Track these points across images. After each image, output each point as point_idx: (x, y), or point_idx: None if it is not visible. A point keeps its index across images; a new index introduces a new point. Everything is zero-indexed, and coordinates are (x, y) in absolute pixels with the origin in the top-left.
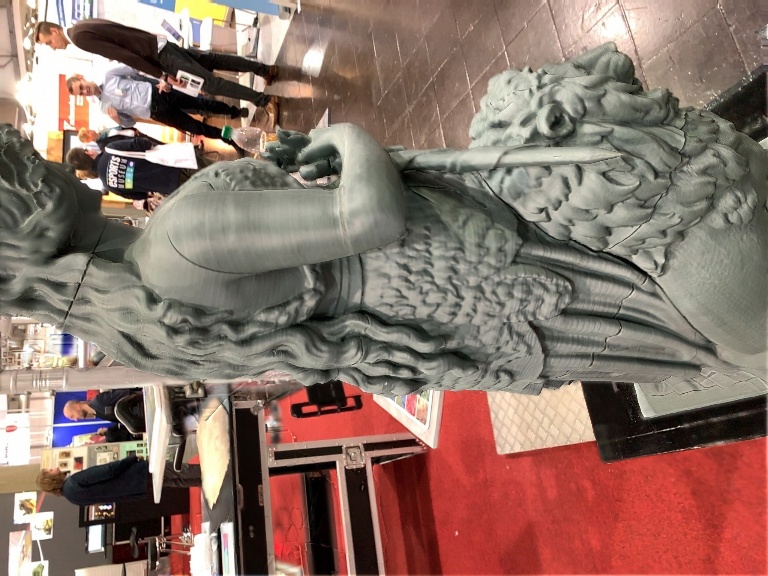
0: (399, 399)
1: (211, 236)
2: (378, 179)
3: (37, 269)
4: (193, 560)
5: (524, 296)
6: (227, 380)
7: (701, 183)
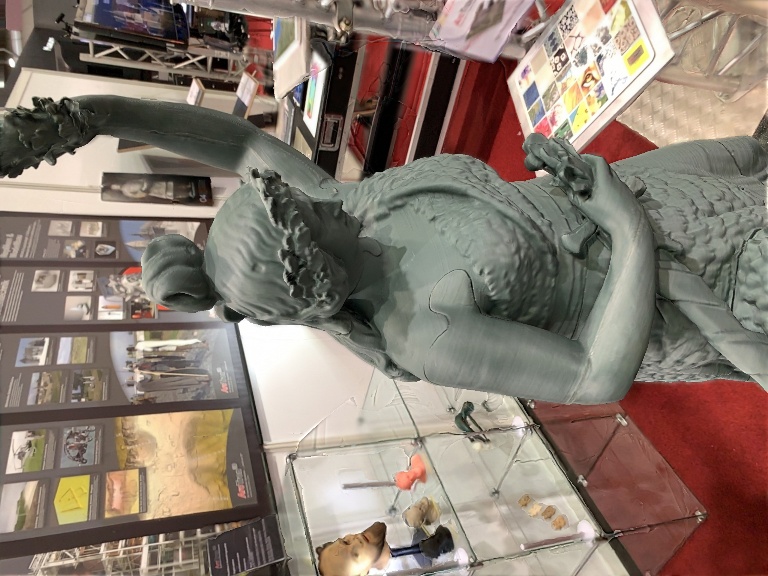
0: (533, 113)
1: (459, 383)
2: (625, 373)
3: (302, 322)
4: None
5: None
6: (372, 30)
7: None
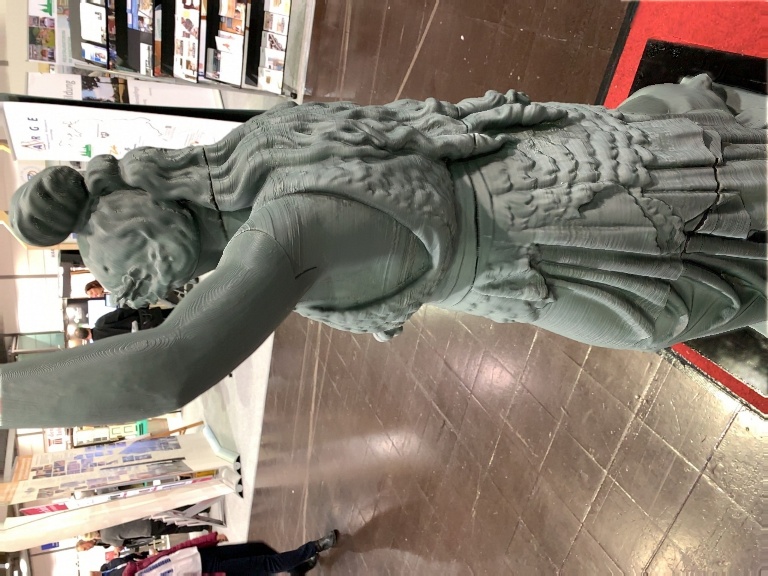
0: None
1: None
2: None
3: None
4: None
5: None
6: None
7: None
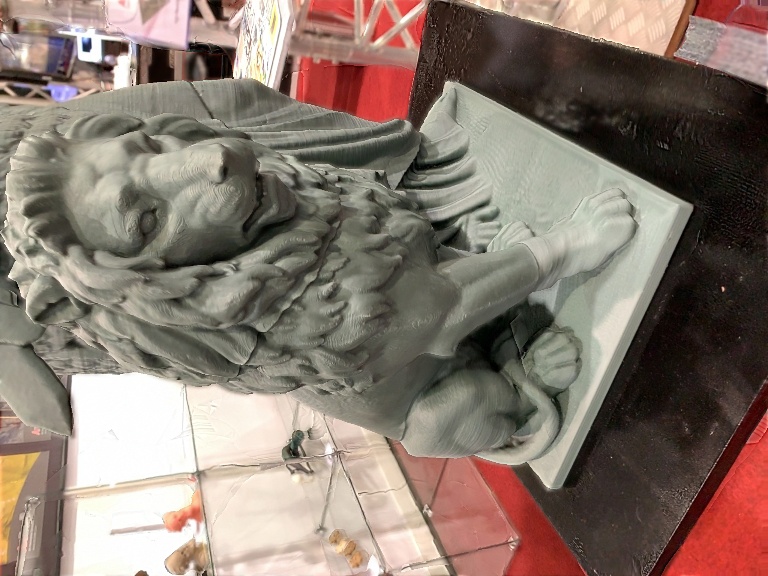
0: None
1: None
2: None
3: None
4: (117, 80)
5: (87, 367)
6: (43, 18)
7: (272, 386)
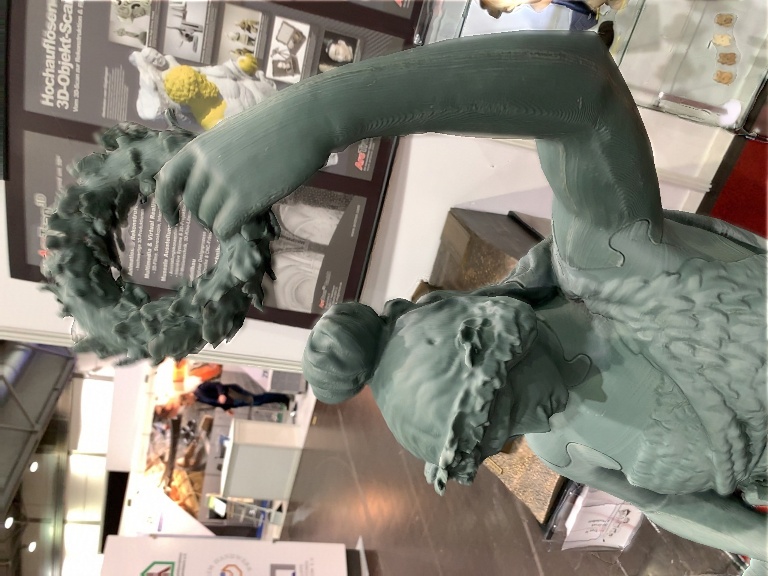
0: None
1: None
2: None
3: None
4: None
5: None
6: None
7: None
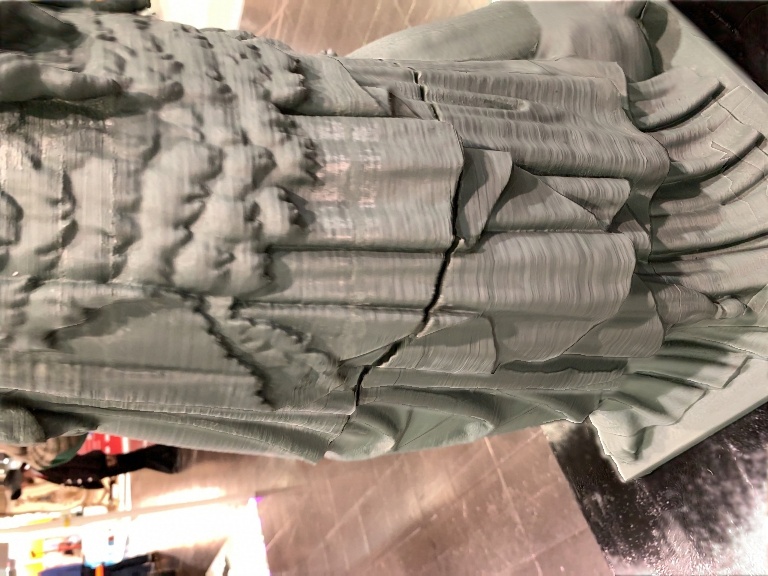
0: None
1: None
2: None
3: None
4: None
5: None
6: None
7: None
